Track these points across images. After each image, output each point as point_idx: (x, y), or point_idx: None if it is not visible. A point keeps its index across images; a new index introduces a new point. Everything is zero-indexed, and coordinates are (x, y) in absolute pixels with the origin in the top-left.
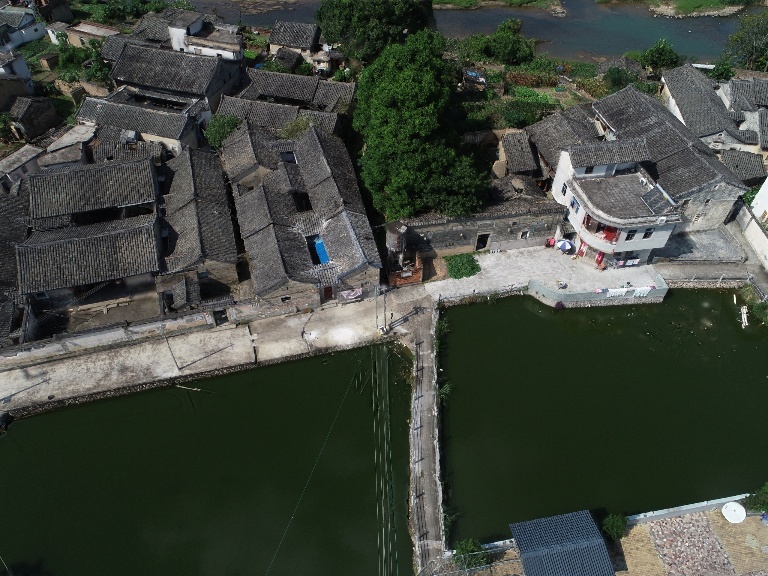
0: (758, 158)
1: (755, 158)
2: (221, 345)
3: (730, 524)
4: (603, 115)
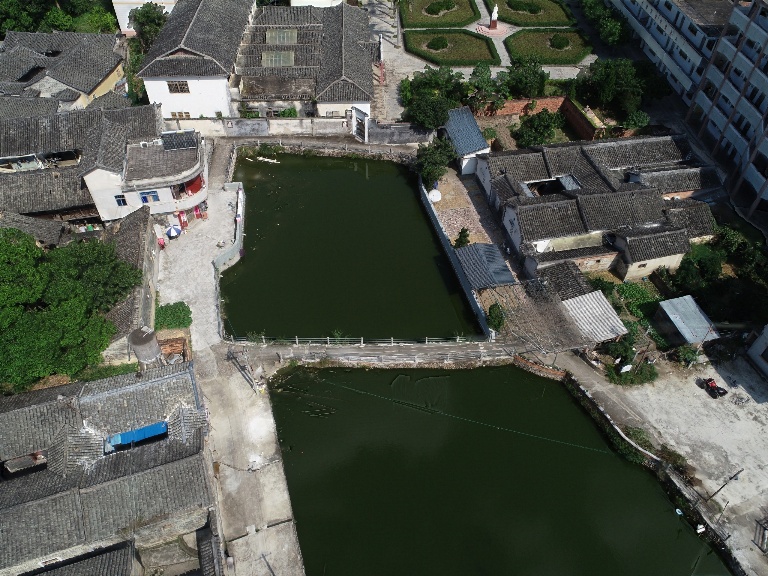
0: (112, 94)
1: (112, 95)
2: (262, 571)
3: (439, 202)
4: (1, 156)
